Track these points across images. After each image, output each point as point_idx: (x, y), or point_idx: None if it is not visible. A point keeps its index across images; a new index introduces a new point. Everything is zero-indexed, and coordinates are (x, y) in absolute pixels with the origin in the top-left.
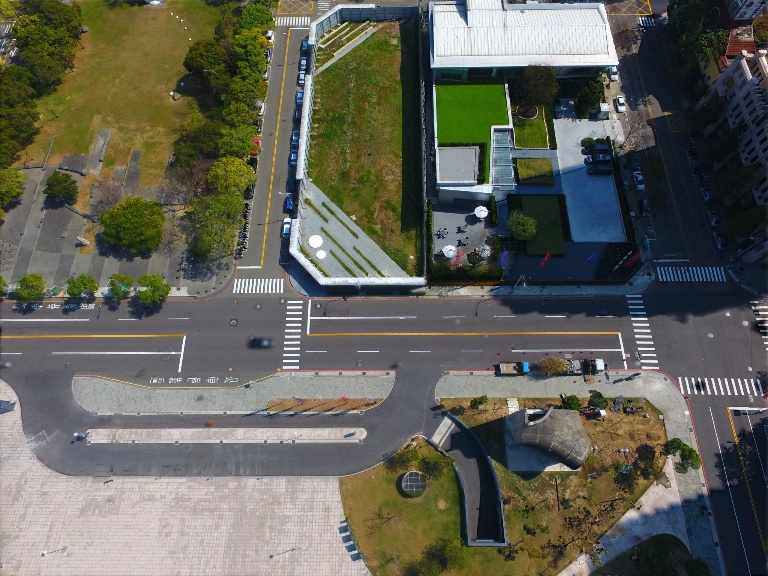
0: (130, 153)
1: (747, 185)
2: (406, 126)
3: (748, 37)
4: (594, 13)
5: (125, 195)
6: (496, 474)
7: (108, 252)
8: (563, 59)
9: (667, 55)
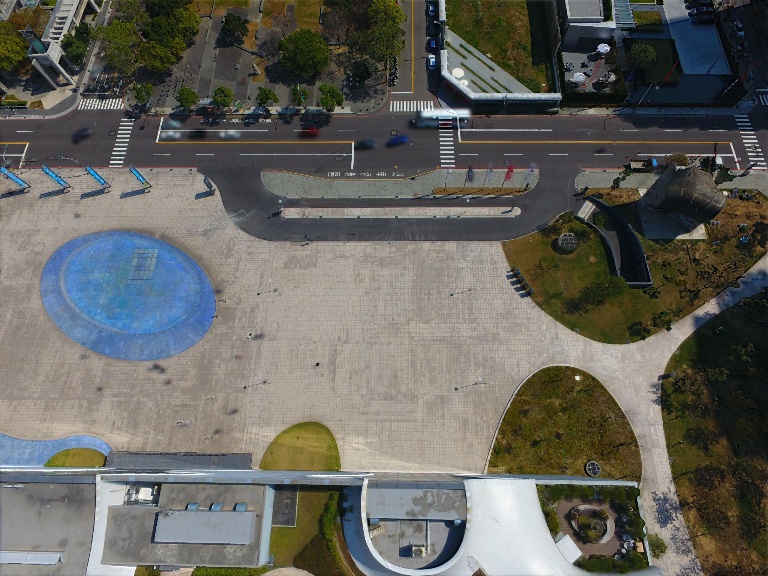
0: (285, 6)
1: None
2: None
3: None
4: None
5: (294, 29)
6: None
7: (277, 80)
8: None
9: None
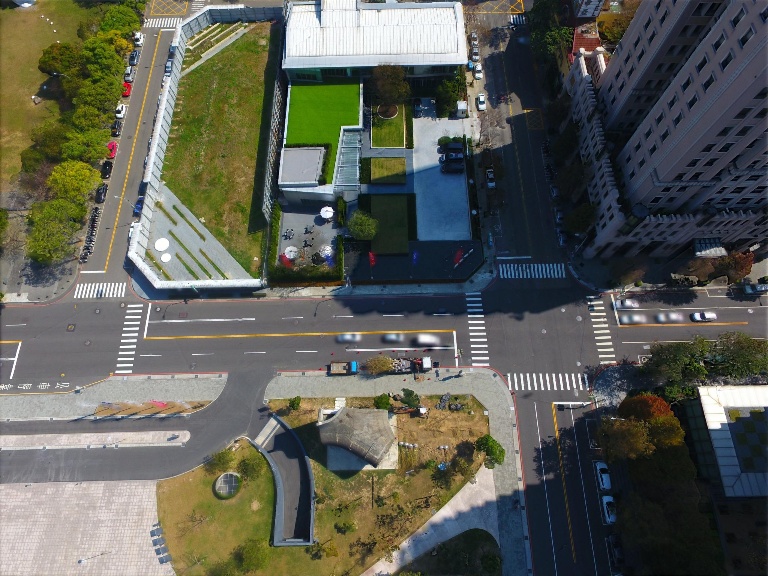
0: None
1: (584, 182)
2: (264, 127)
3: (593, 34)
4: (449, 12)
5: None
6: (313, 474)
7: None
8: (413, 58)
9: None
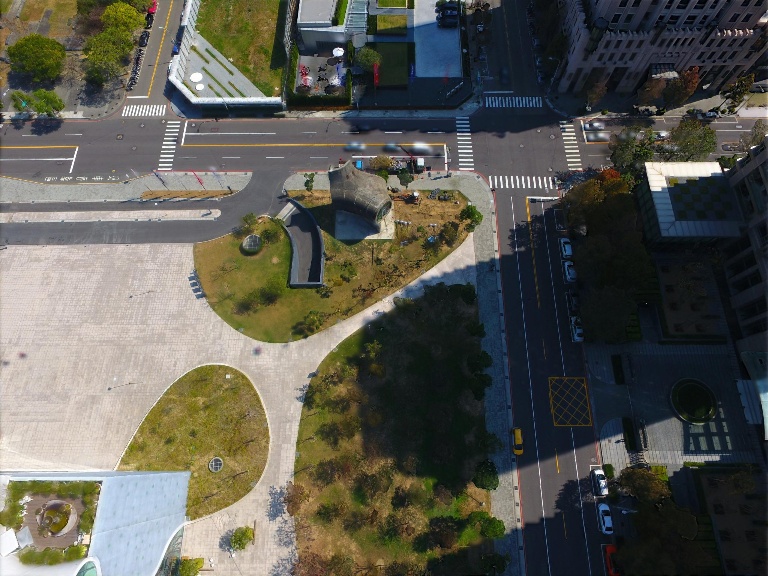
0: (43, 11)
1: (560, 24)
2: None
3: None
4: None
5: None
6: (323, 240)
7: (18, 86)
8: None
9: None
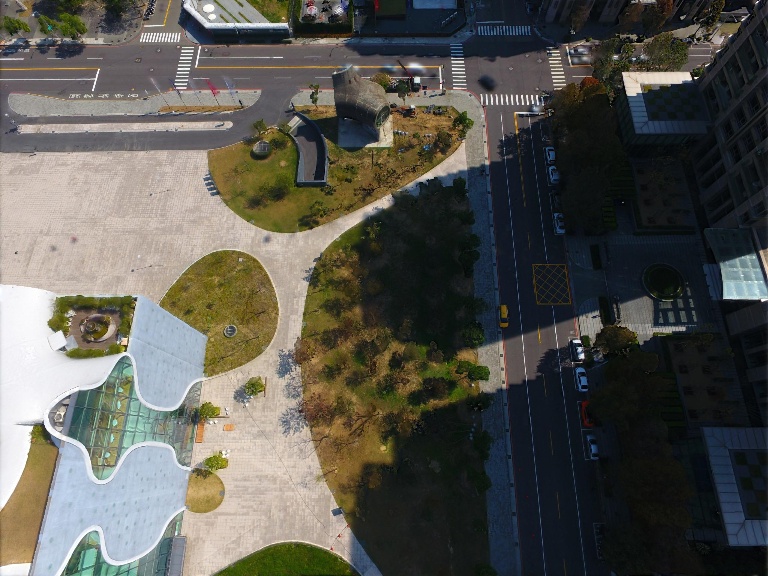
0: None
1: None
2: None
3: None
4: None
5: None
6: (327, 147)
7: None
8: None
9: None
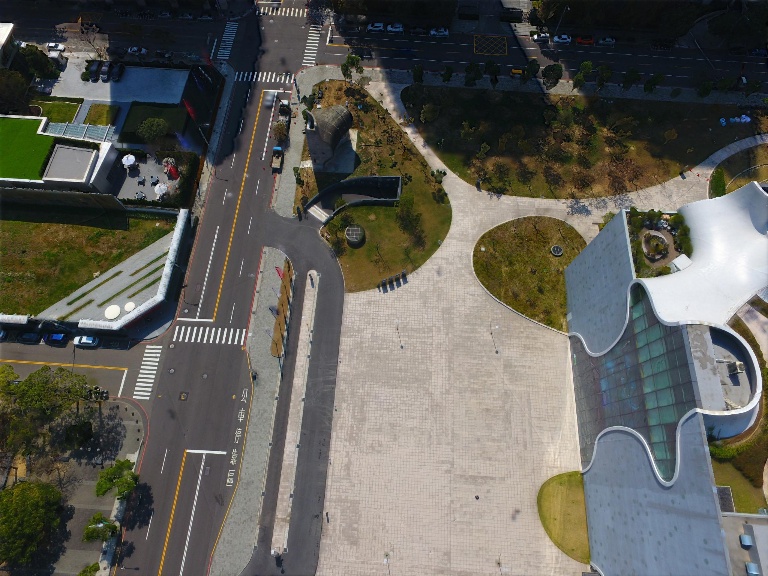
0: None
1: None
2: (2, 216)
3: None
4: None
5: None
6: (354, 180)
7: (46, 571)
8: None
9: (18, 6)
